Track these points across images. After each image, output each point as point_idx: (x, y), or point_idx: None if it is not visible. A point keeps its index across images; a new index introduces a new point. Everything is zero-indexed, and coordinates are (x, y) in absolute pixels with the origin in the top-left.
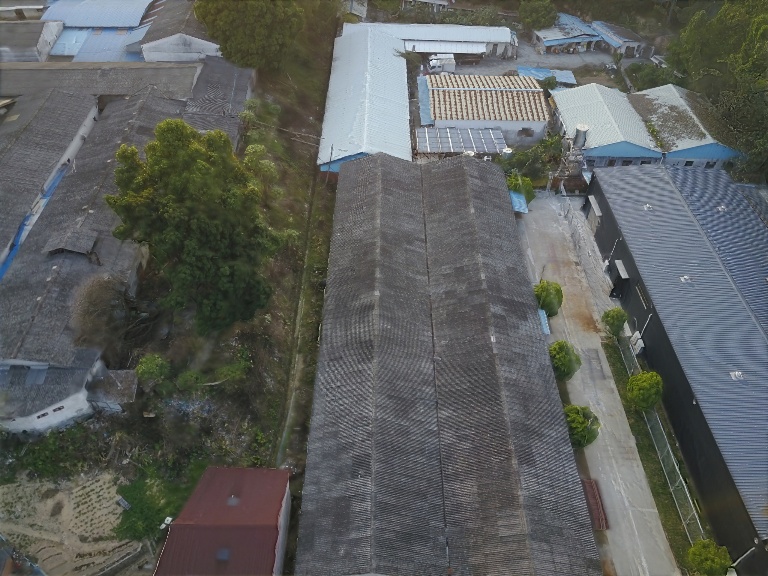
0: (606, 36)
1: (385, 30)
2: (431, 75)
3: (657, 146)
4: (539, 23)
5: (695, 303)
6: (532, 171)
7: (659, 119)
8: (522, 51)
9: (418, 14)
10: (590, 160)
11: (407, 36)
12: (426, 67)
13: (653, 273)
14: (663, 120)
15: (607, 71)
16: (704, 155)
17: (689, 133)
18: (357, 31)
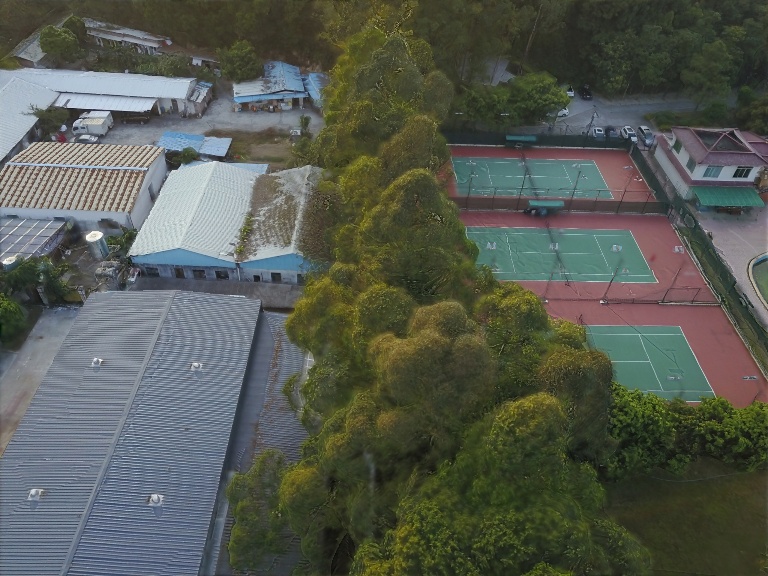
0: (315, 92)
1: (41, 79)
2: (39, 142)
3: (234, 253)
4: (237, 75)
5: (9, 541)
6: (51, 286)
7: (266, 213)
8: (216, 107)
9: (120, 57)
10: (151, 268)
11: (64, 88)
12: (71, 127)
13: (4, 480)
14: (268, 215)
15: (290, 137)
16: (289, 266)
17: (279, 236)
18: (2, 80)
